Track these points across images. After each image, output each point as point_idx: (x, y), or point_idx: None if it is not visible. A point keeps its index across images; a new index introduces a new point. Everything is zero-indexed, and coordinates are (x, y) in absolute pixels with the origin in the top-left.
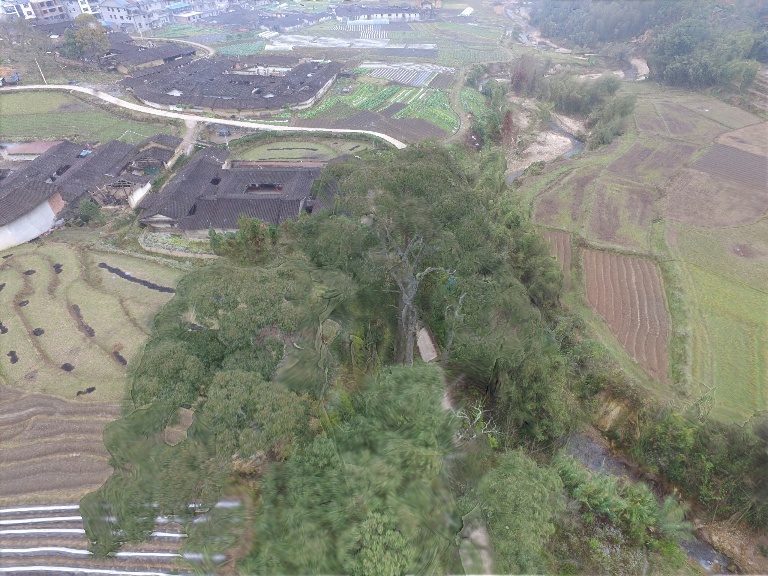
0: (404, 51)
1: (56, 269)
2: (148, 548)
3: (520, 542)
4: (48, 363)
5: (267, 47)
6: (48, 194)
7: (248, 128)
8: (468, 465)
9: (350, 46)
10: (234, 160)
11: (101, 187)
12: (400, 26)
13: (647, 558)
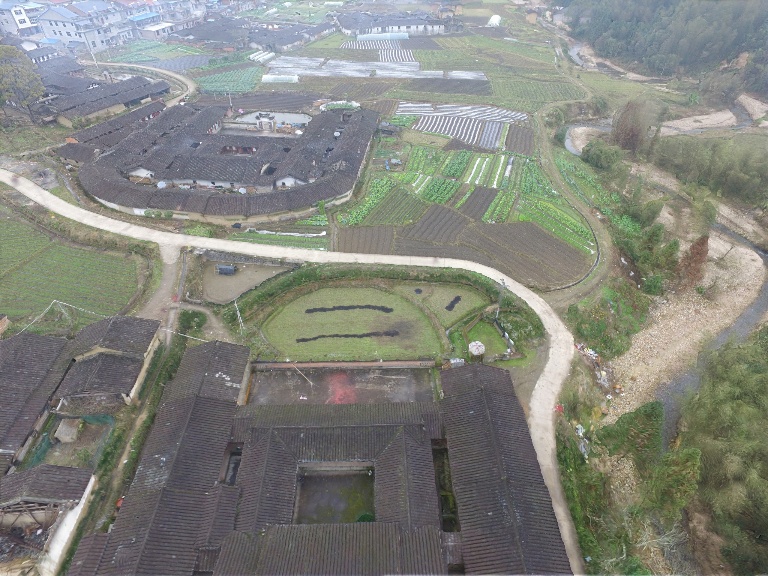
0: (446, 83)
1: None
2: None
3: None
4: None
5: (264, 78)
6: None
7: (266, 258)
8: None
9: (372, 75)
10: (255, 355)
11: None
12: (423, 42)
13: None
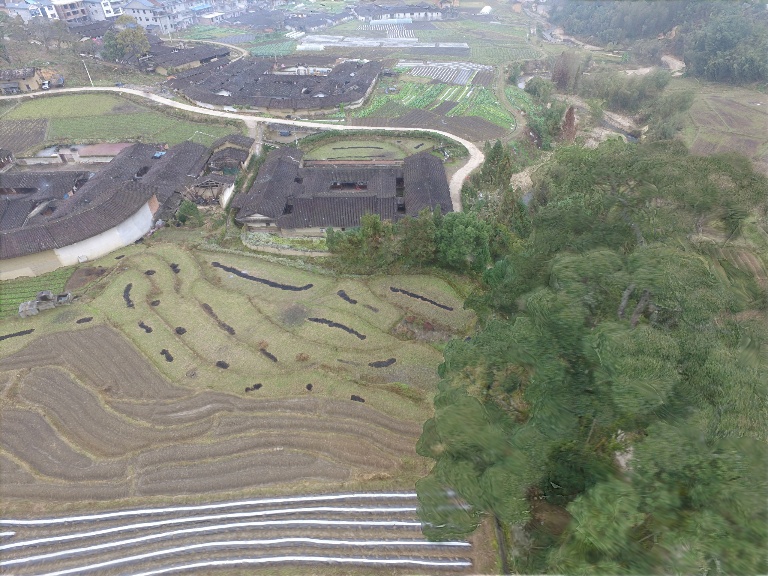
0: (436, 50)
1: (173, 269)
2: (390, 537)
3: None
4: (204, 361)
5: (298, 47)
6: (148, 195)
7: (308, 128)
8: None
9: (380, 45)
10: (305, 159)
11: (188, 188)
12: (424, 25)
13: None
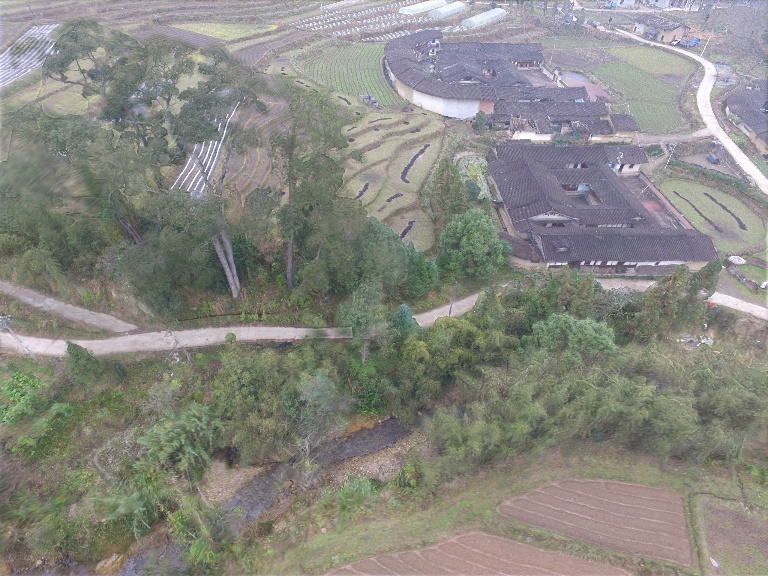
0: None
1: (415, 131)
2: None
3: (158, 380)
4: None
5: None
6: (482, 97)
7: (740, 169)
8: (136, 255)
9: None
10: None
11: None
12: None
13: (113, 479)
